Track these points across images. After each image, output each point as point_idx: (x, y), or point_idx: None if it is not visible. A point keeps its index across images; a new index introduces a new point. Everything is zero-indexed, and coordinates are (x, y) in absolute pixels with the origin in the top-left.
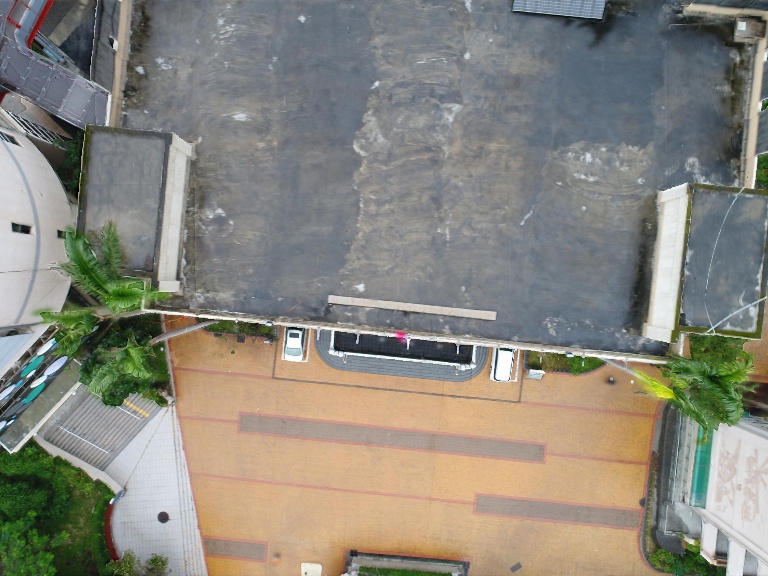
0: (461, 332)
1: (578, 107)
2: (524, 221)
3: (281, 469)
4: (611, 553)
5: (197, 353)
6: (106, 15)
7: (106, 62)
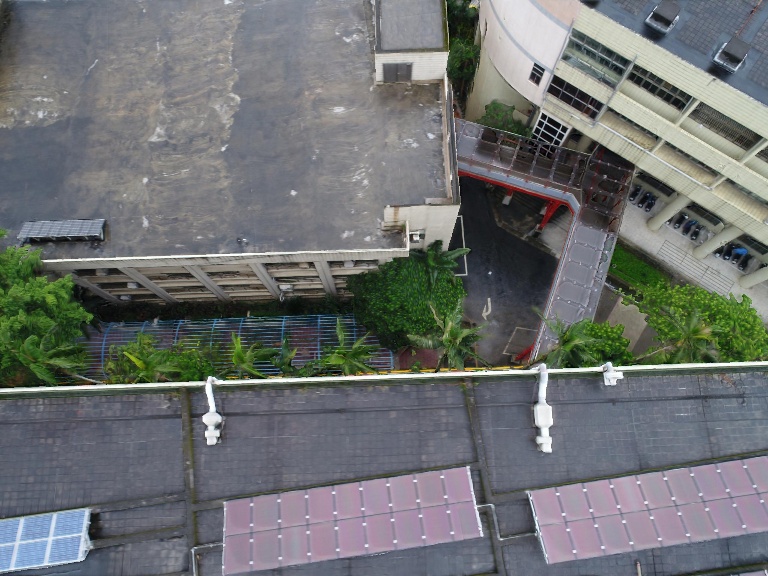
0: None
1: (48, 152)
2: (95, 63)
3: None
4: None
5: None
6: None
7: None
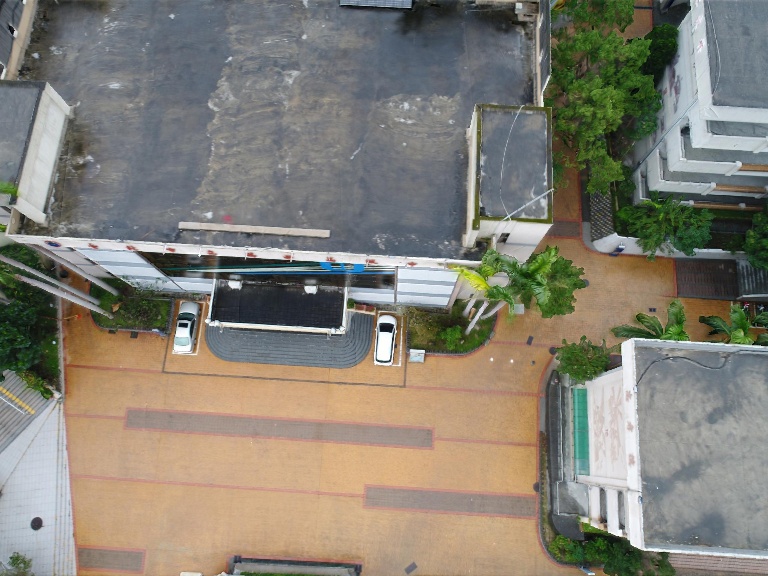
0: (299, 249)
1: (396, 70)
2: (353, 156)
3: (165, 466)
4: (510, 546)
5: (90, 350)
6: (7, 6)
7: (3, 41)
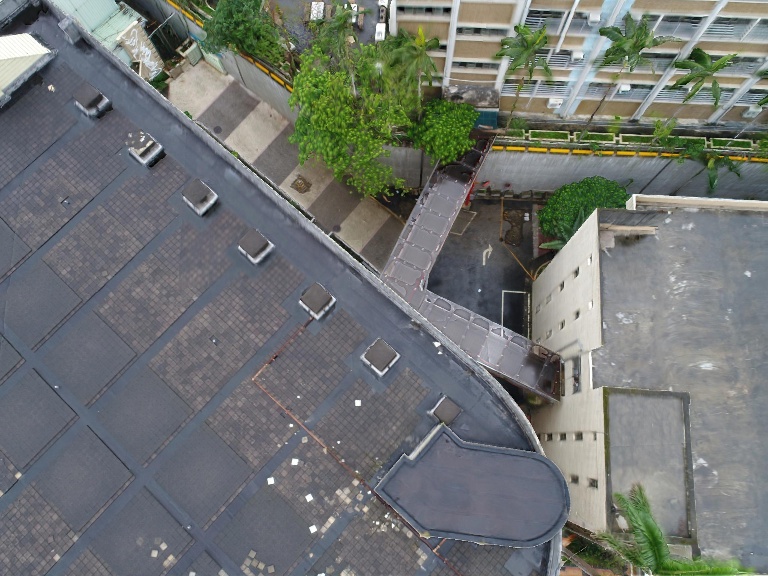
0: None
1: None
2: None
3: None
4: None
5: None
6: None
7: None
